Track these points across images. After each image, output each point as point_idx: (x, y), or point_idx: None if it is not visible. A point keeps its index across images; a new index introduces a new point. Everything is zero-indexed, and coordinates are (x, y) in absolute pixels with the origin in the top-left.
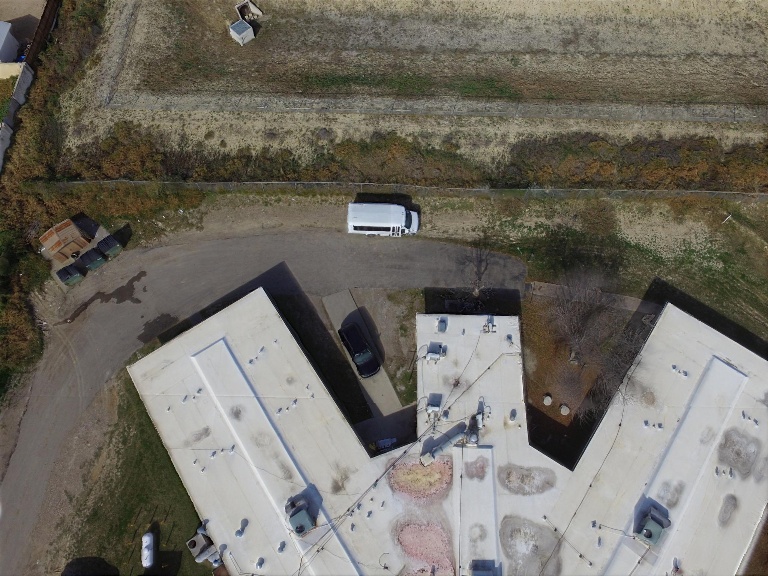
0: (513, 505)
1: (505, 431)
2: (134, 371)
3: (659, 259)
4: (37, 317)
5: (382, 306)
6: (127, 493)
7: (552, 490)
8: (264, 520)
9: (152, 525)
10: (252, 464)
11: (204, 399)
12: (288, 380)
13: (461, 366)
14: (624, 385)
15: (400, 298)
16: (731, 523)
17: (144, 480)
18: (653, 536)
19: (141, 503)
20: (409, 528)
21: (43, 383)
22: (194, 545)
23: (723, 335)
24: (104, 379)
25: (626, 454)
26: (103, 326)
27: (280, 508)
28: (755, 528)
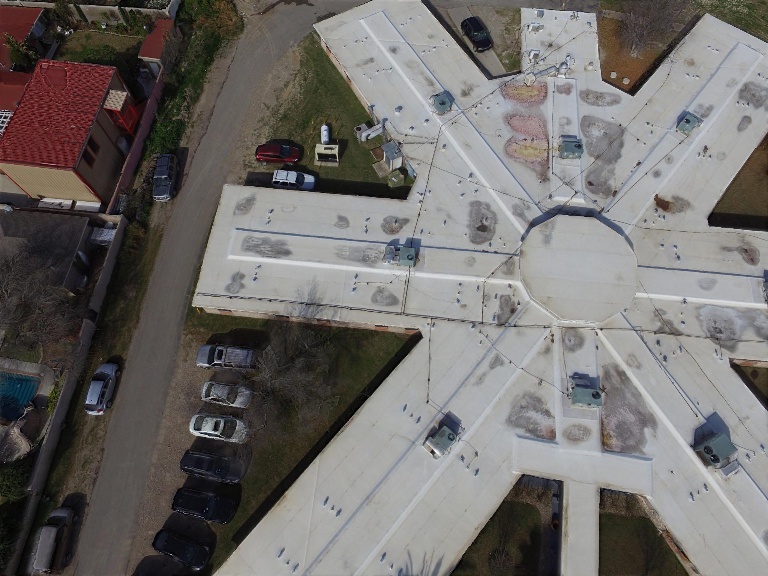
0: (590, 110)
1: (585, 73)
2: (319, 26)
3: (699, 4)
4: (238, 10)
5: (491, 17)
6: (308, 107)
7: (618, 105)
8: (414, 107)
9: (327, 124)
10: (405, 77)
11: (369, 43)
12: (429, 37)
13: (554, 36)
14: (672, 54)
15: (505, 13)
16: (747, 131)
17: (320, 100)
18: (691, 122)
19: (318, 112)
20: (516, 117)
21: (245, 46)
22: (360, 129)
23: (746, 33)
24: (289, 45)
25: (672, 90)
26: (287, 17)
27: (425, 100)
28: (764, 134)
